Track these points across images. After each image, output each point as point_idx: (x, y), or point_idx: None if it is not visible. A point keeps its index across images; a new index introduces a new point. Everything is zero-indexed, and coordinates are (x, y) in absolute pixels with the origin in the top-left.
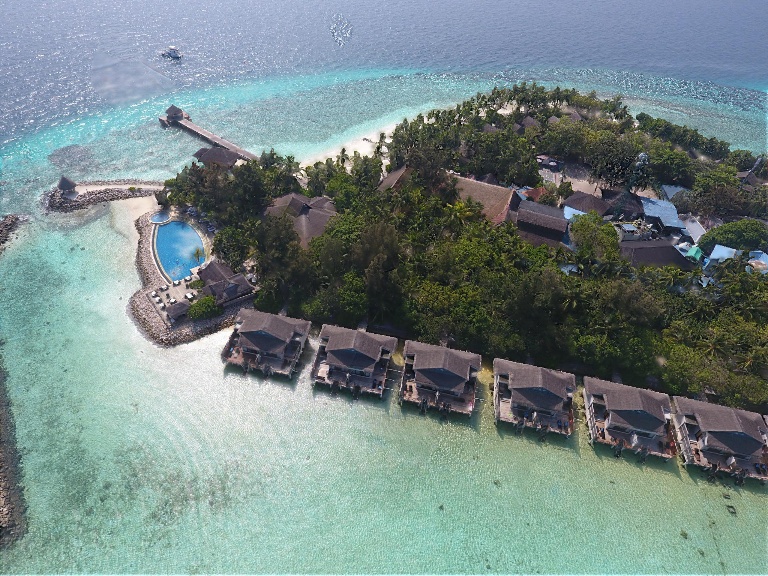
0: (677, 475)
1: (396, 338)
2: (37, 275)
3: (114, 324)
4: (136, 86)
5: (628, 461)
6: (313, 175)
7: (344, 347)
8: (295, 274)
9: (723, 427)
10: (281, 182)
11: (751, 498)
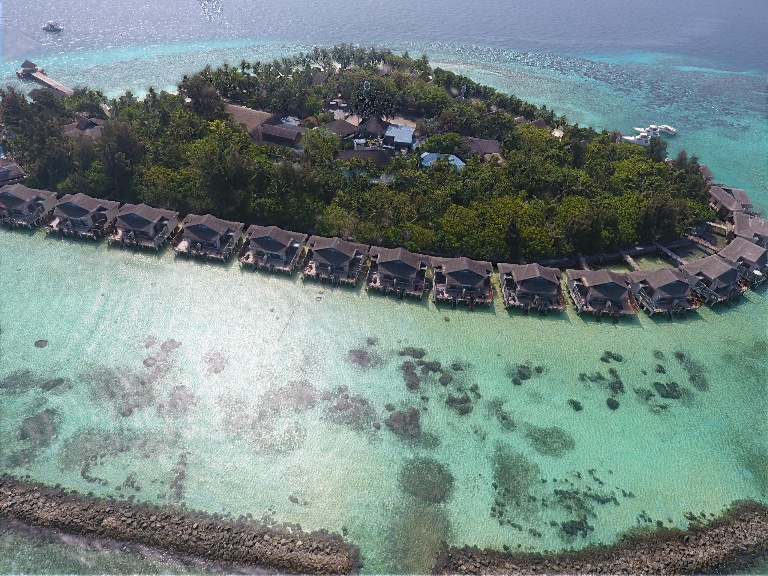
0: (293, 282)
1: (118, 202)
2: None
3: None
4: (8, 49)
5: (262, 275)
6: (111, 103)
7: (65, 202)
8: (52, 161)
9: (324, 247)
10: (84, 109)
11: (339, 294)
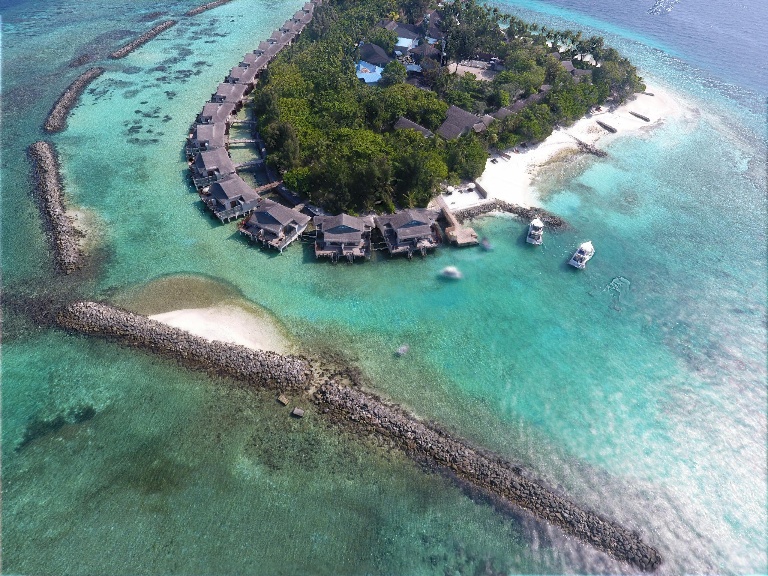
0: None
1: None
2: None
3: None
4: None
5: None
6: None
7: None
8: None
9: None
10: None
11: None
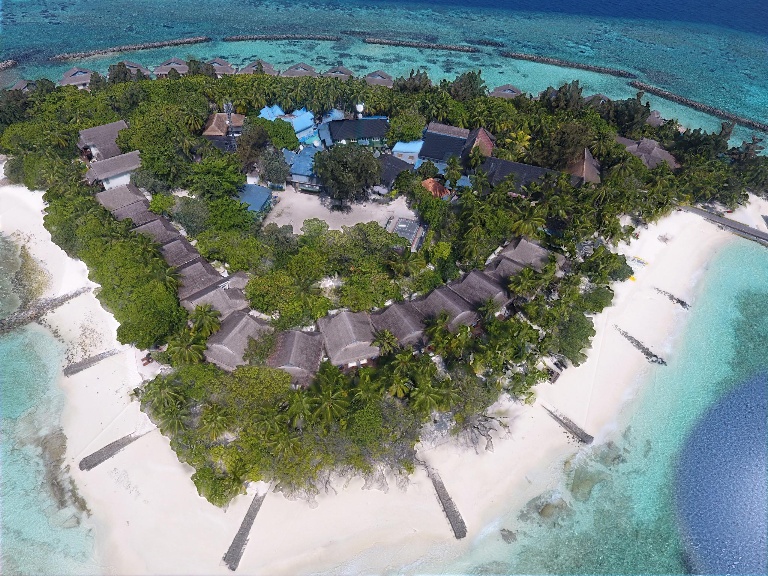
0: None
1: None
2: (761, 143)
3: (681, 124)
4: None
5: None
6: None
7: None
8: None
9: (385, 73)
10: None
11: None
